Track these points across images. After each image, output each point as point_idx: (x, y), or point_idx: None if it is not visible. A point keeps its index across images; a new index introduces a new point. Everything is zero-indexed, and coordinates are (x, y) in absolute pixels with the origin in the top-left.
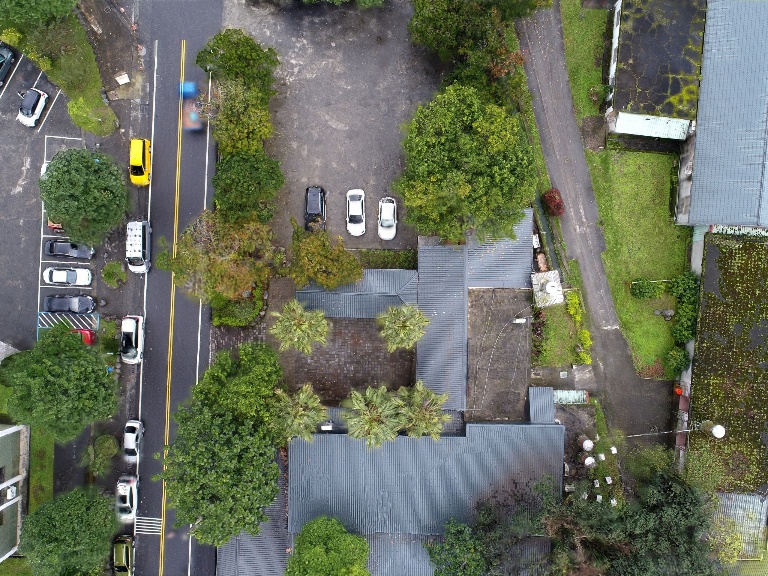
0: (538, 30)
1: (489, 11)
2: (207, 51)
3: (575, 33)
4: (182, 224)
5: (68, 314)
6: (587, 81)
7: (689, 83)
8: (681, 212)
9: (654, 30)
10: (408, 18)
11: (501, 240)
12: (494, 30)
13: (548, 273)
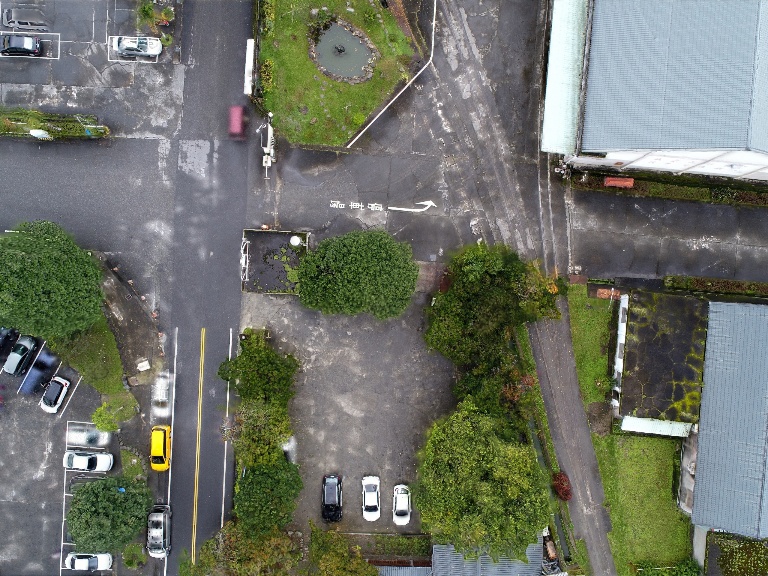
0: (546, 318)
1: (502, 334)
2: (229, 362)
3: (582, 322)
4: (201, 507)
5: None
6: (593, 369)
7: (692, 389)
8: (684, 502)
9: (658, 339)
10: (421, 308)
11: None
12: (507, 356)
13: (558, 575)
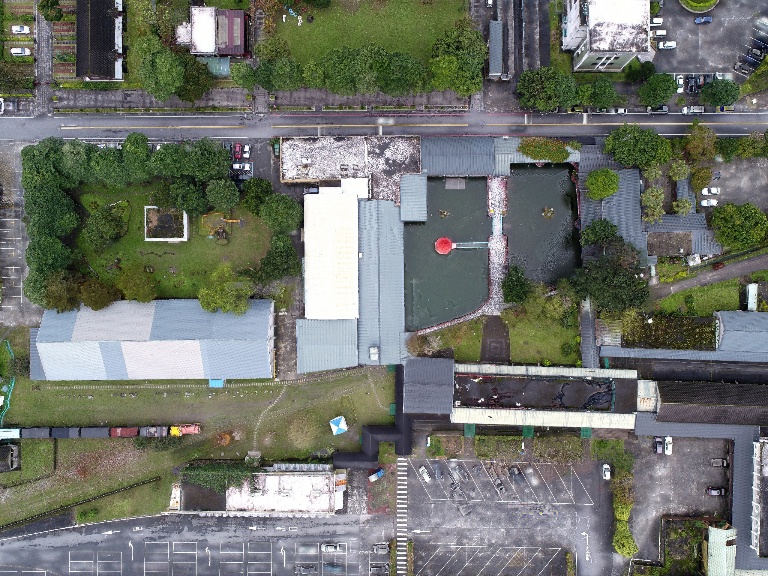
0: None
1: None
2: None
3: None
4: None
5: None
6: (765, 276)
7: None
8: None
9: None
10: None
11: (710, 243)
12: None
13: None
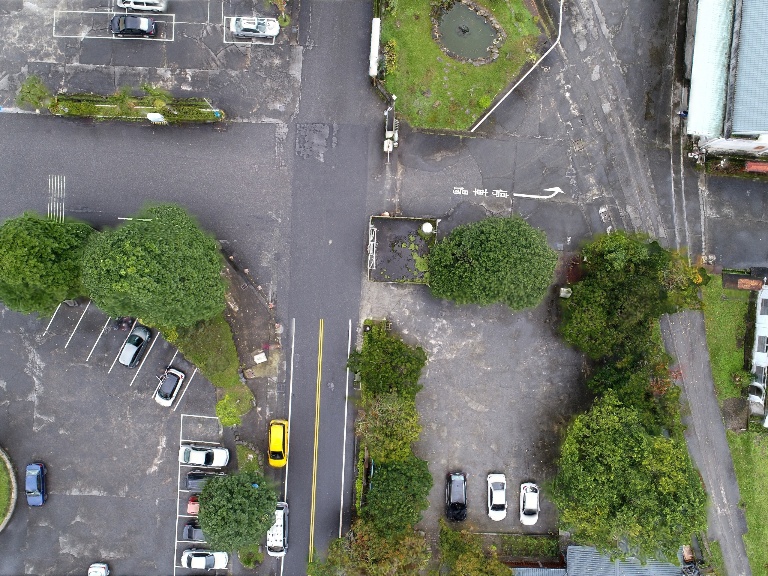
0: (679, 310)
1: (647, 325)
2: (357, 354)
3: (716, 314)
4: (319, 504)
5: None
6: (729, 363)
7: None
8: None
9: None
10: (549, 299)
11: None
12: (654, 348)
13: None
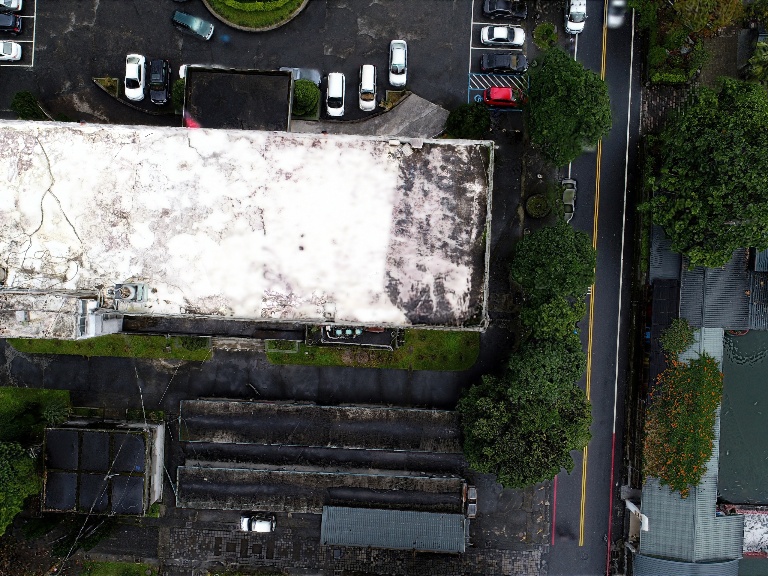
0: None
1: None
2: None
3: None
4: None
5: (499, 75)
6: None
7: None
8: None
9: None
10: None
11: None
12: None
13: None
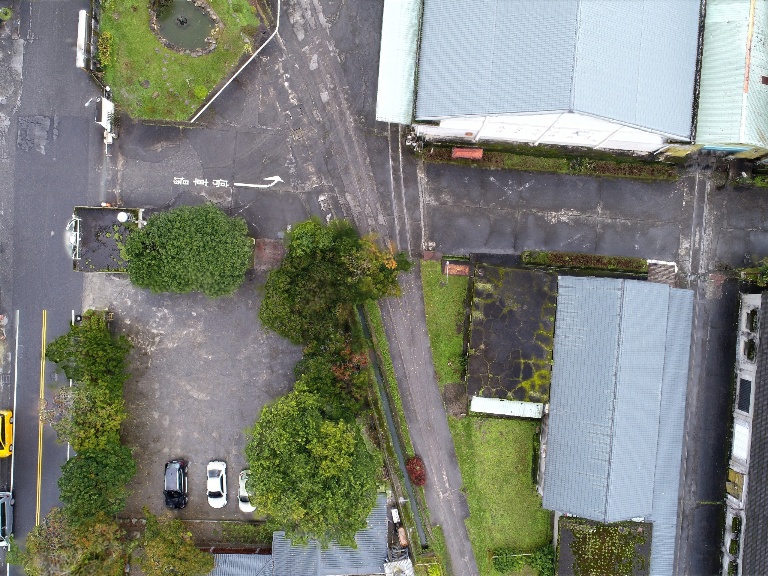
0: (399, 297)
1: (333, 311)
2: None
3: (436, 300)
4: (45, 494)
5: None
6: (448, 348)
7: (541, 368)
8: (540, 486)
9: (505, 315)
10: None
11: None
12: (337, 333)
13: (400, 562)
